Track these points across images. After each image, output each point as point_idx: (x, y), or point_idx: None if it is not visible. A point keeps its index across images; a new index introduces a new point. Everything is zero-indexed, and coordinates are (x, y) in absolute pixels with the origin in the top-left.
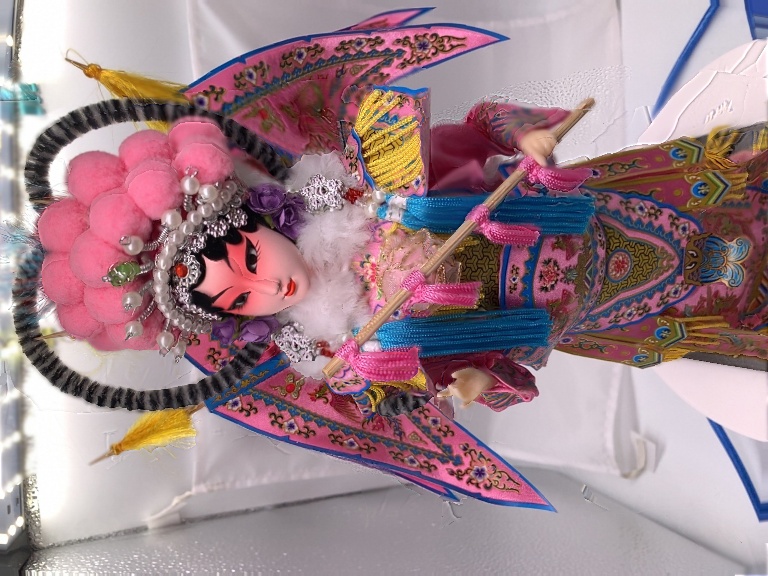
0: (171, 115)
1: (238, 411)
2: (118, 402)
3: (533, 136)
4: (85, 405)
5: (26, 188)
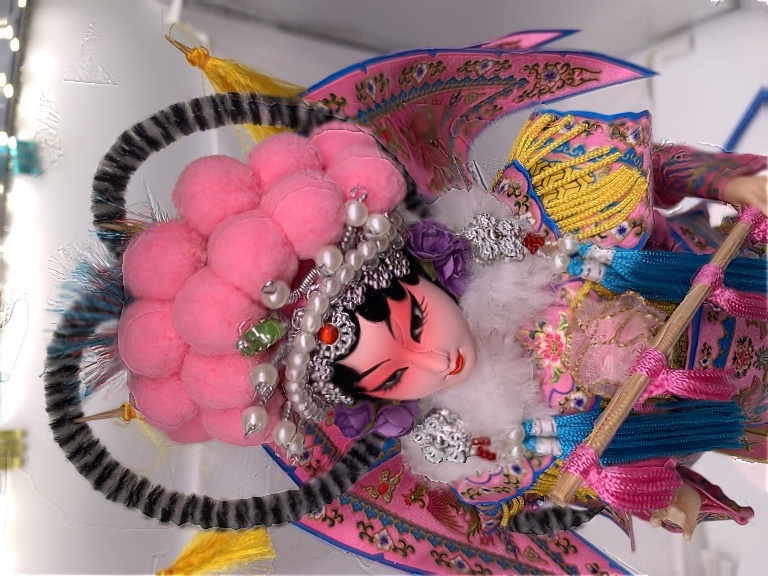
0: (305, 120)
1: (320, 519)
2: (190, 517)
3: (754, 182)
4: (139, 519)
5: (92, 206)
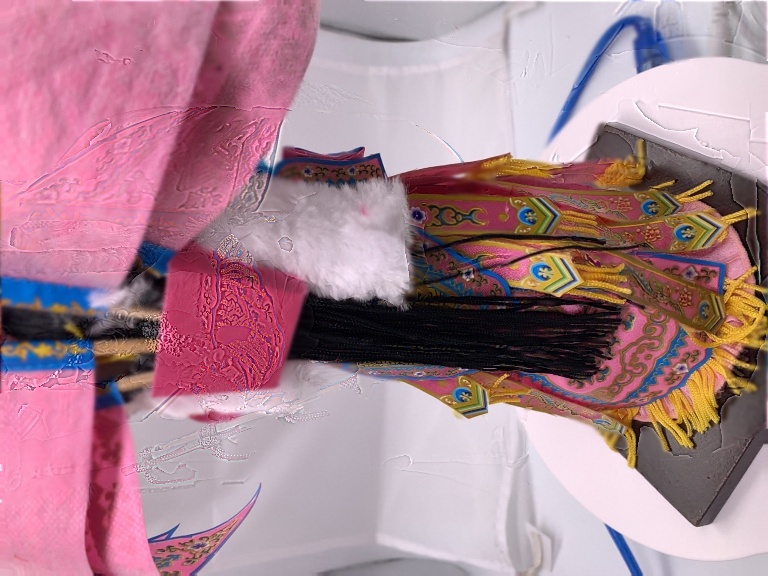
0: (2, 274)
1: None
2: None
3: None
4: None
5: None
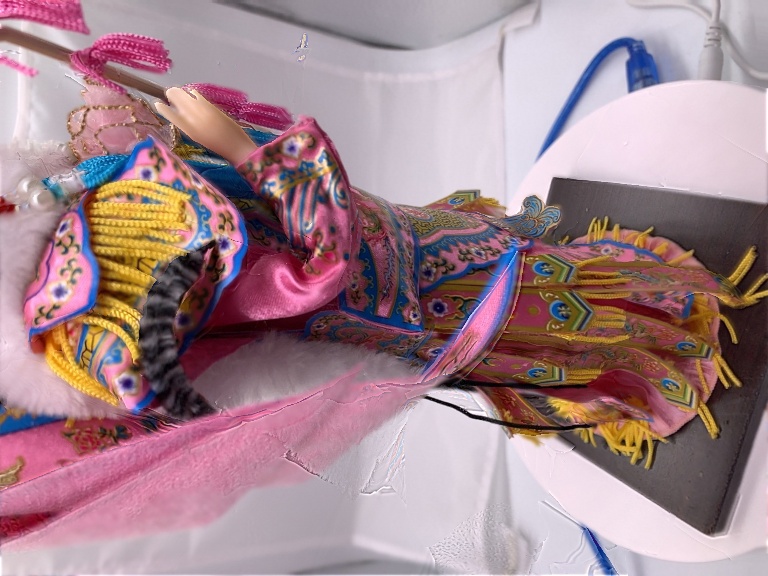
0: None
1: None
2: None
3: None
4: None
5: None
